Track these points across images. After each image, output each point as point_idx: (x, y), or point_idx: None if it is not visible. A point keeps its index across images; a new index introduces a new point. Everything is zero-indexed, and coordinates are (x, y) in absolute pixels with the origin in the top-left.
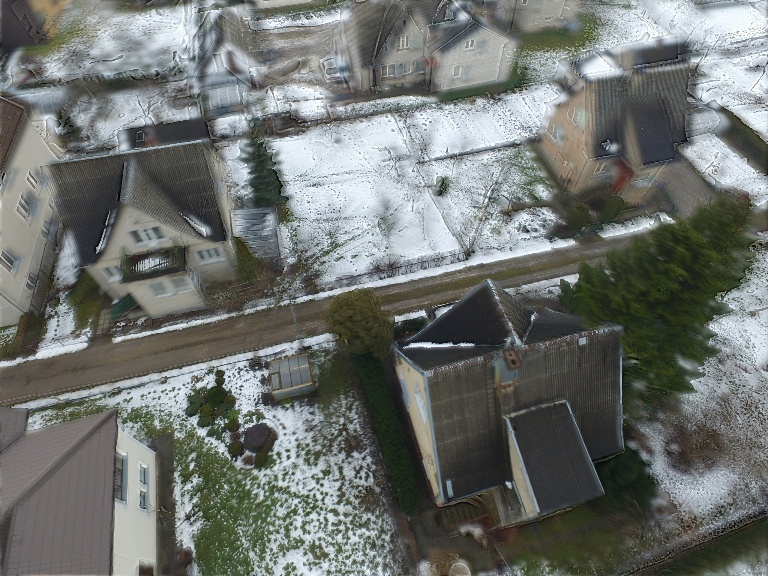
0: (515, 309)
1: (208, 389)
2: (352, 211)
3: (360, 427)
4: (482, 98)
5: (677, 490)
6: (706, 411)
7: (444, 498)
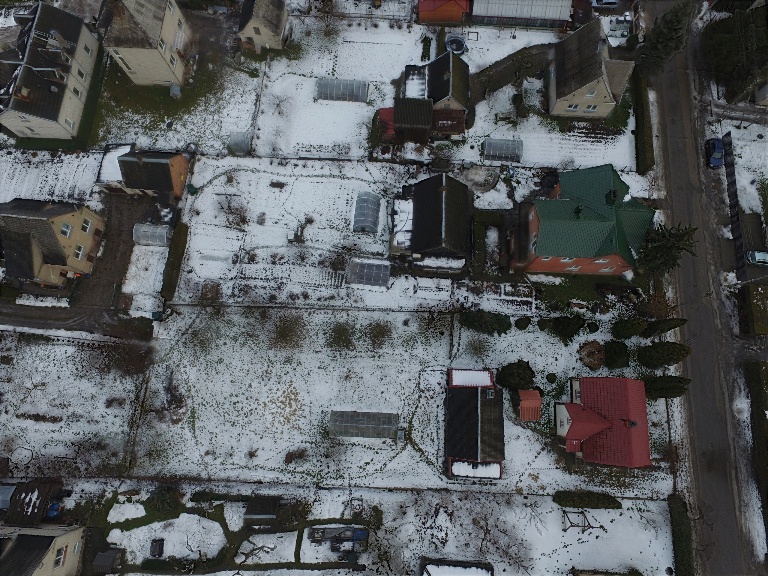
0: None
1: None
2: None
3: None
4: (51, 155)
5: None
6: None
7: None
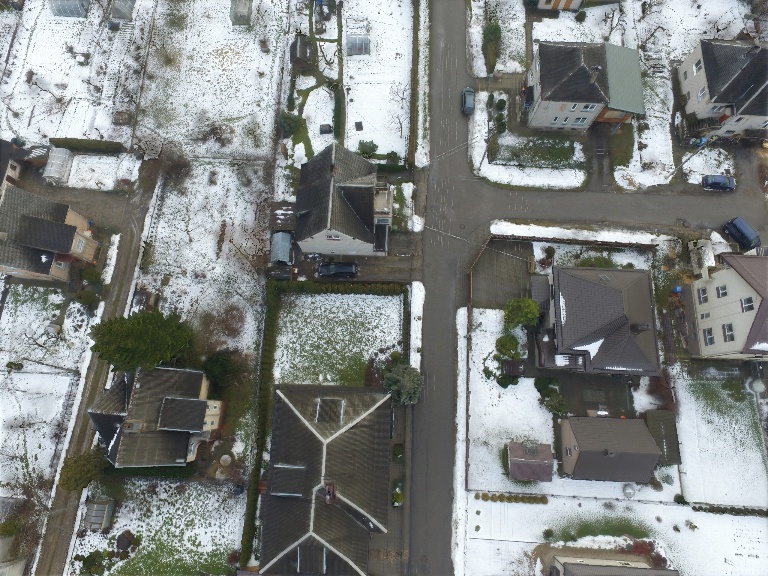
0: (113, 398)
1: (82, 567)
2: (2, 434)
3: (146, 482)
4: None
5: (241, 342)
6: (219, 305)
7: (183, 464)
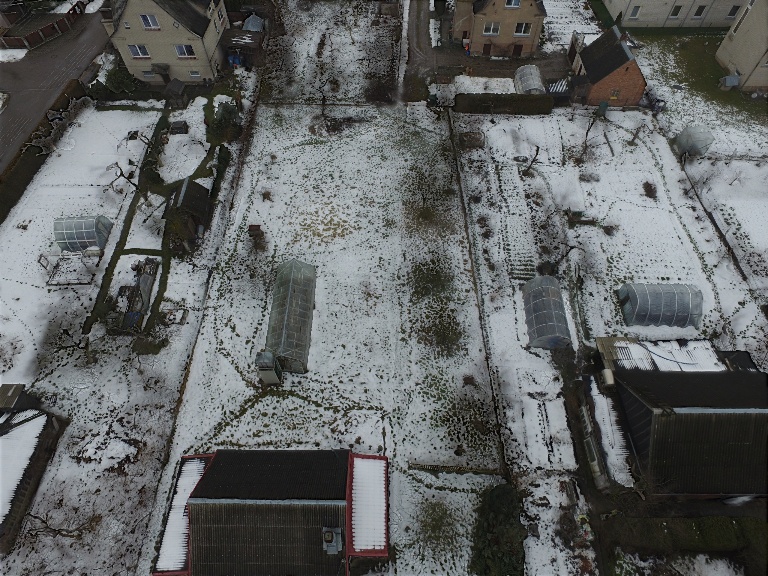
0: None
1: None
2: None
3: None
4: (591, 17)
5: None
6: (320, 8)
7: None
